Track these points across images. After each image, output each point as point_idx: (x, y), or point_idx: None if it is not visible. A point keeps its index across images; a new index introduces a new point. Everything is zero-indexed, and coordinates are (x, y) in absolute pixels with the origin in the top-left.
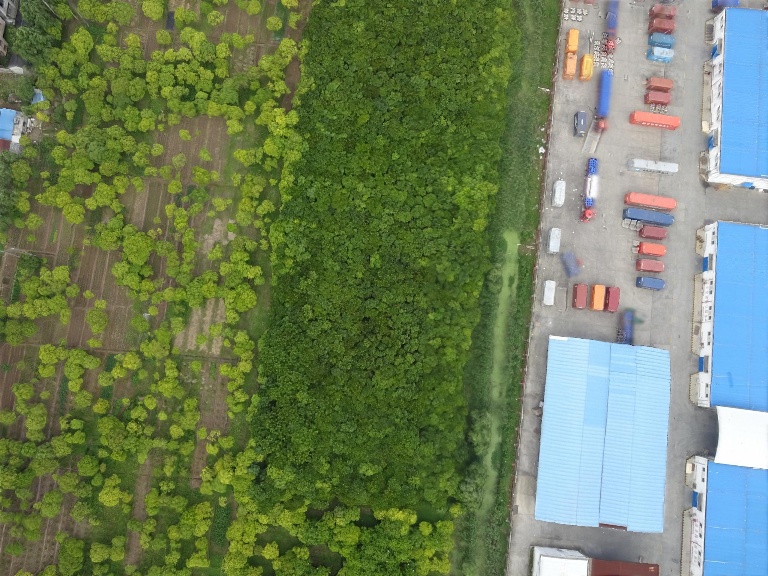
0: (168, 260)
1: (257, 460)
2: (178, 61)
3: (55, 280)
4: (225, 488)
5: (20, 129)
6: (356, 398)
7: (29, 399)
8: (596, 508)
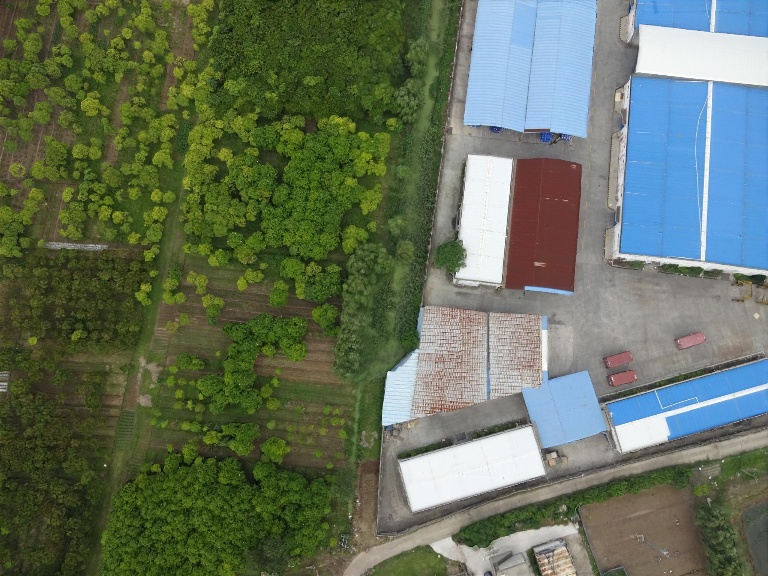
0: None
1: (216, 77)
2: None
3: None
4: (188, 102)
5: None
6: (301, 19)
7: (27, 29)
8: (522, 116)
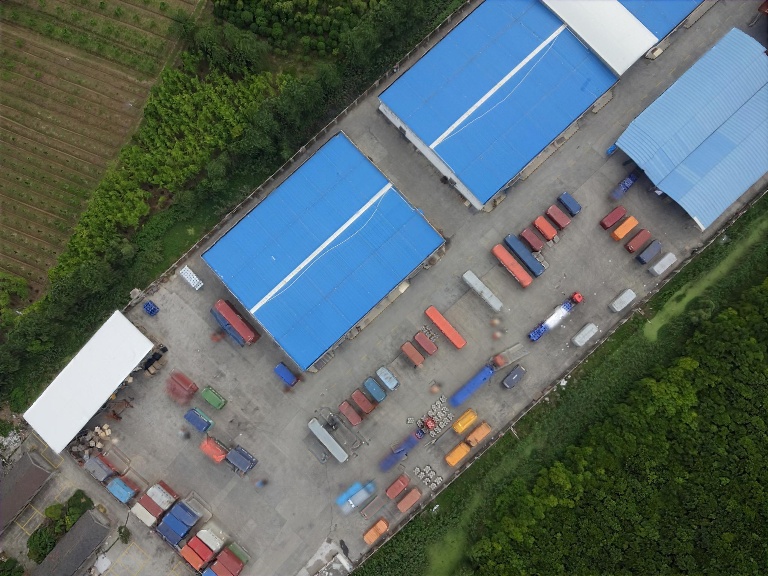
0: None
1: None
2: None
3: None
4: None
5: None
6: None
7: None
8: None
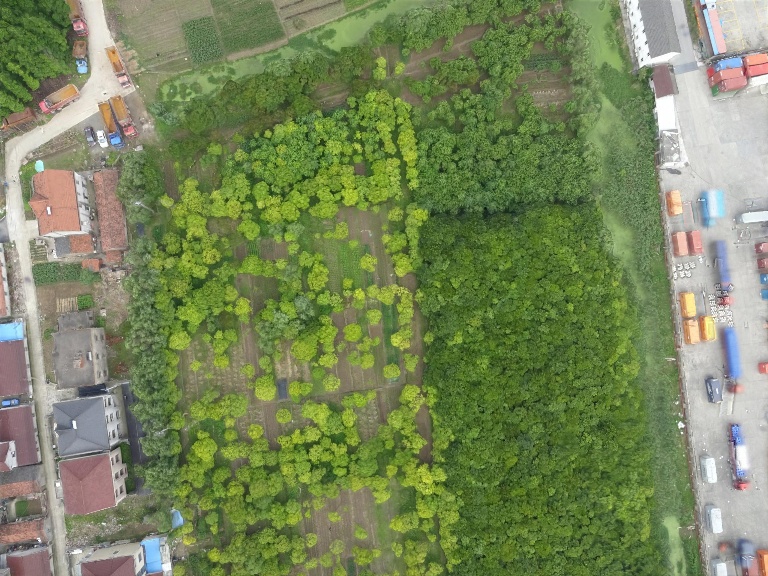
0: None
1: None
2: (308, 444)
3: None
4: None
5: (168, 555)
6: None
7: None
8: None
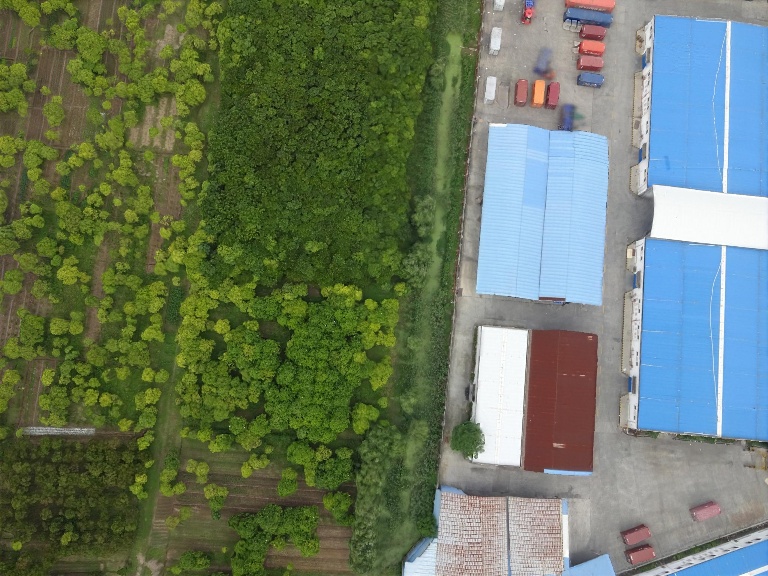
0: (120, 56)
1: (208, 241)
2: None
3: (12, 75)
4: (178, 268)
5: None
6: (301, 178)
7: None
8: (536, 283)
